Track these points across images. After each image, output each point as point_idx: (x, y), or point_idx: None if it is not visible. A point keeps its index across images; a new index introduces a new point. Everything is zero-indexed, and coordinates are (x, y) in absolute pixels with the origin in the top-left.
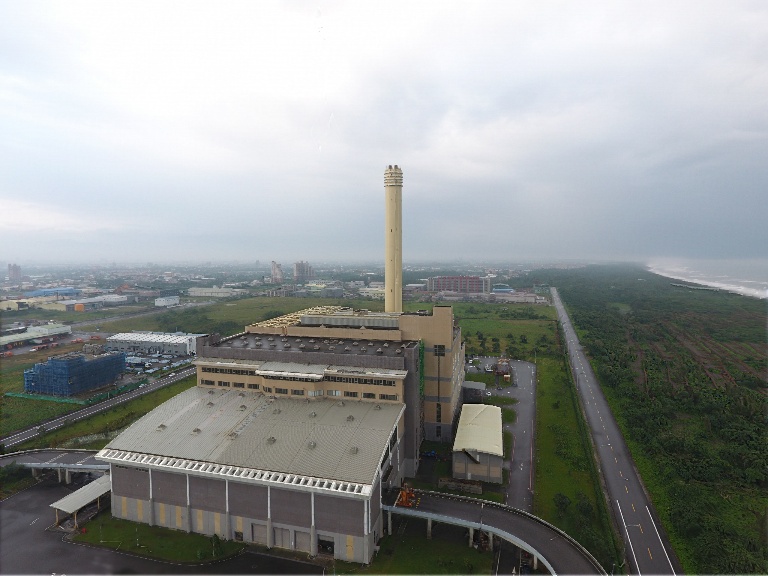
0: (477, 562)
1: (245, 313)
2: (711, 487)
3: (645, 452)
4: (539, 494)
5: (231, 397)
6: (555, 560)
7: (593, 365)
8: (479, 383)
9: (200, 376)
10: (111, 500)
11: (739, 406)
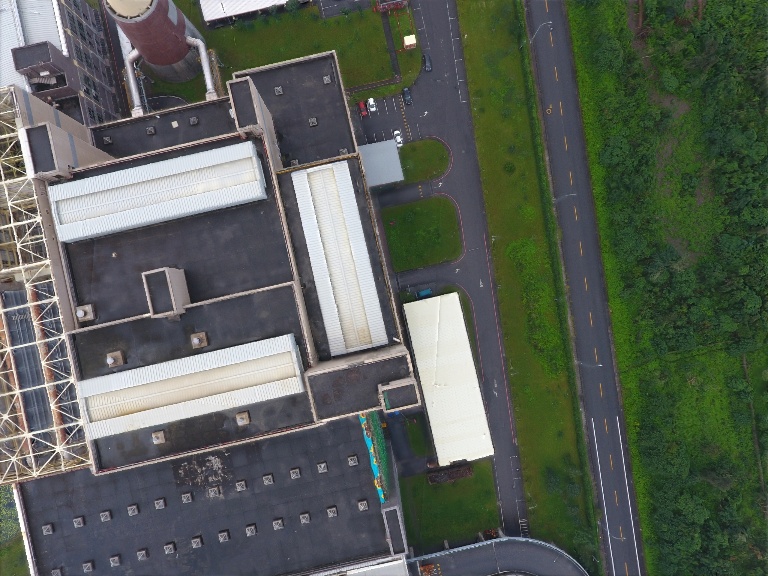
0: None
1: None
2: (680, 355)
3: (624, 286)
4: (524, 448)
5: None
6: None
7: None
8: (385, 148)
9: None
10: None
11: (764, 82)
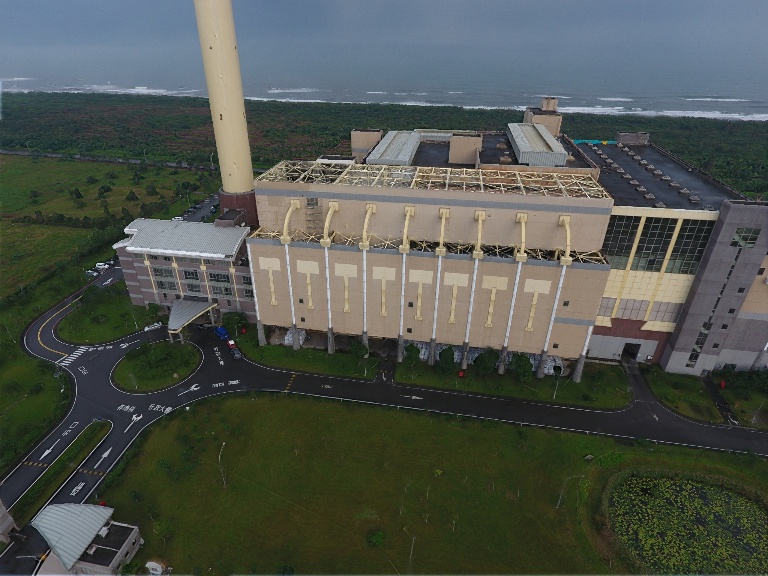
0: None
1: None
2: None
3: None
4: None
5: None
6: None
7: None
8: None
9: None
10: None
11: None
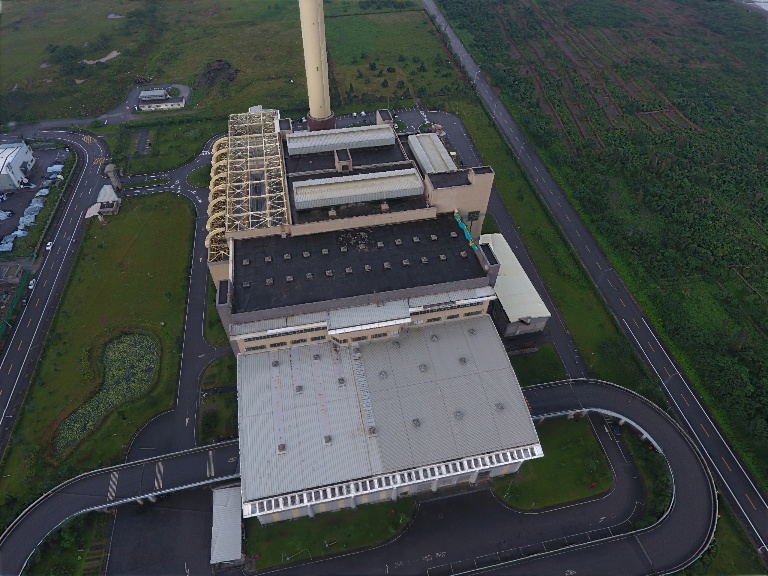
0: (582, 433)
1: (5, 53)
2: (671, 282)
3: (614, 248)
4: (576, 335)
5: (307, 364)
6: (642, 422)
7: (509, 107)
8: None
9: (243, 346)
10: (259, 519)
11: (653, 166)
